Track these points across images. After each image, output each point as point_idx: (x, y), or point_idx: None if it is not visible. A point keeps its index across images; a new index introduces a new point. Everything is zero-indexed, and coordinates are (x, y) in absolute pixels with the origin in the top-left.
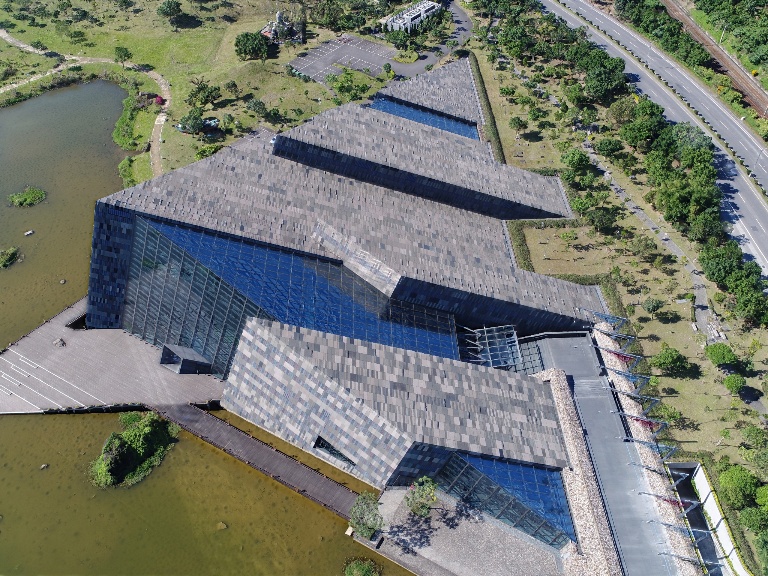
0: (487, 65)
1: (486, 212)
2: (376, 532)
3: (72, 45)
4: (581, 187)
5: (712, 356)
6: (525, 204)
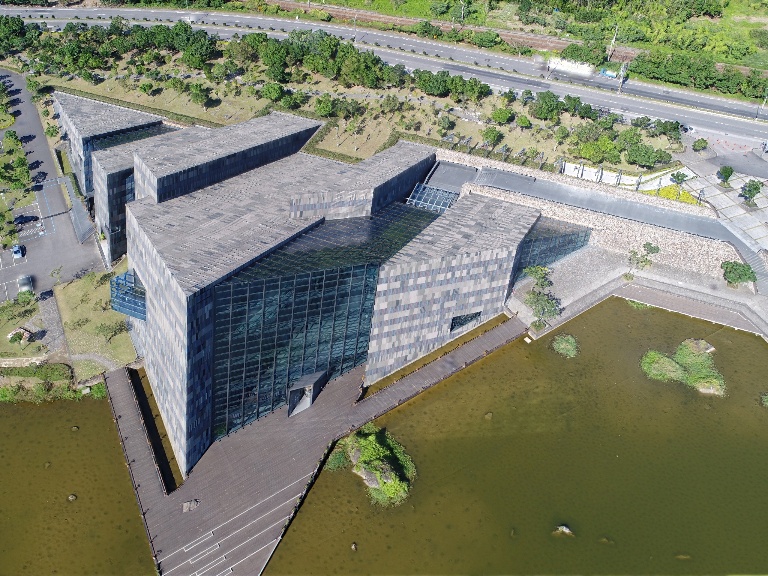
0: (83, 86)
1: (287, 154)
2: None
3: None
4: (296, 106)
5: (501, 118)
6: (302, 130)
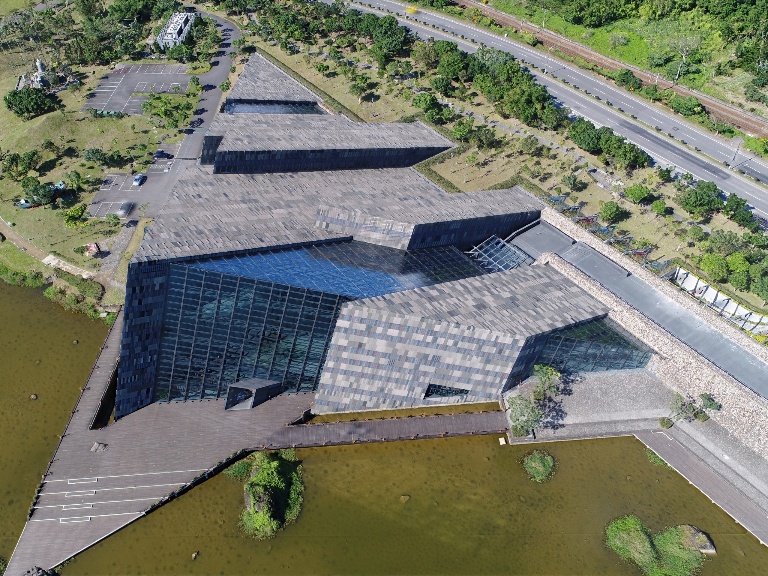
0: (279, 53)
1: (395, 165)
2: None
3: None
4: (442, 122)
5: (634, 196)
6: (422, 147)
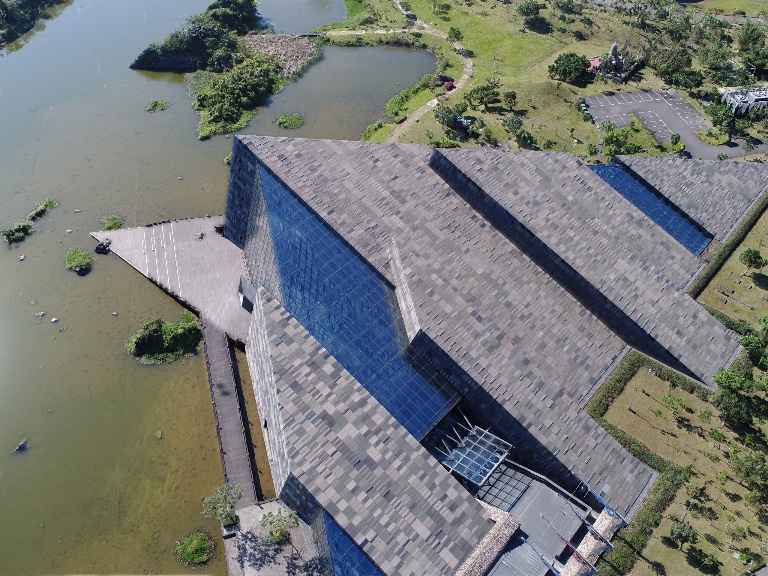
0: None
1: (614, 327)
2: (235, 525)
3: (433, 14)
4: (762, 364)
5: None
6: (660, 342)
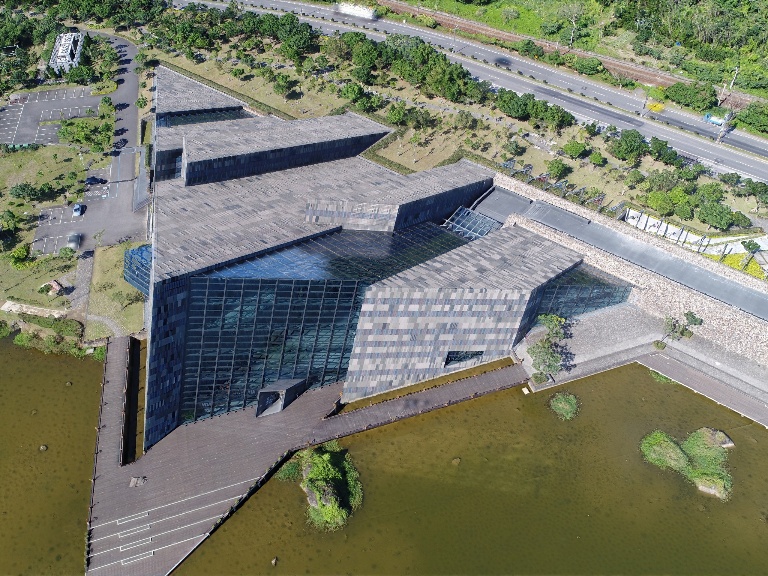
0: (185, 64)
1: (344, 156)
2: None
3: None
4: (372, 110)
5: (573, 152)
6: (365, 135)
